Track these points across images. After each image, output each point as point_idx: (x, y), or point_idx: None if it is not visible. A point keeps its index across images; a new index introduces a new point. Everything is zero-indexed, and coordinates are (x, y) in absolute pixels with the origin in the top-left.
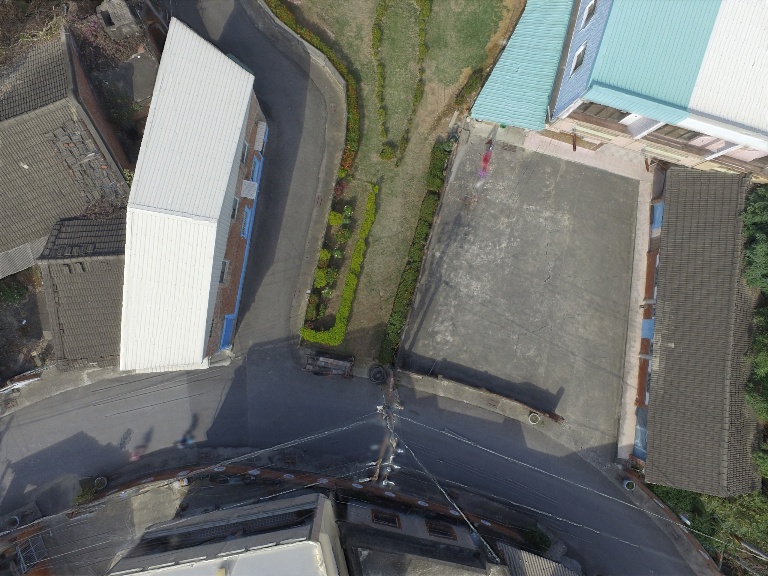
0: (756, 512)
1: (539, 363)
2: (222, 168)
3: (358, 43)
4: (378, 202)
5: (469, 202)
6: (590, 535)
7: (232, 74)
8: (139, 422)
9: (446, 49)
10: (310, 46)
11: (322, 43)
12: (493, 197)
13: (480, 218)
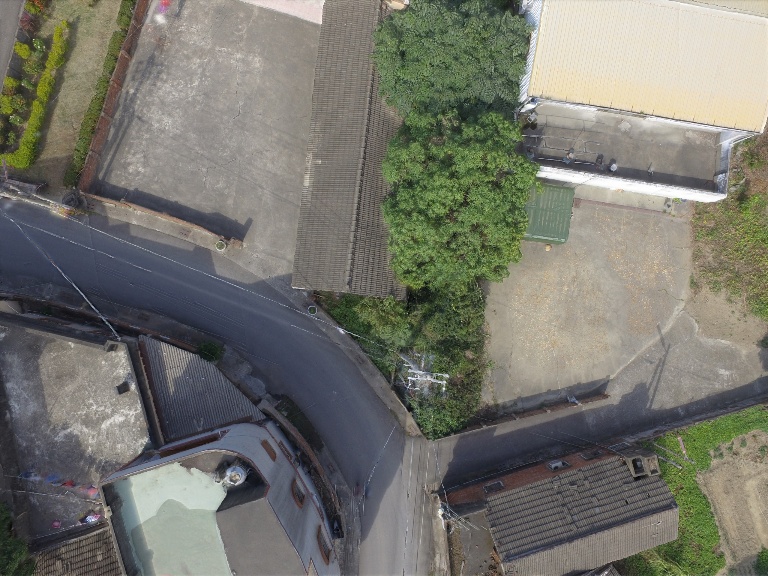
0: (393, 315)
1: (227, 195)
2: None
3: None
4: (74, 40)
5: (163, 43)
6: (275, 357)
7: None
8: None
9: None
10: None
11: None
12: (186, 39)
13: (173, 58)
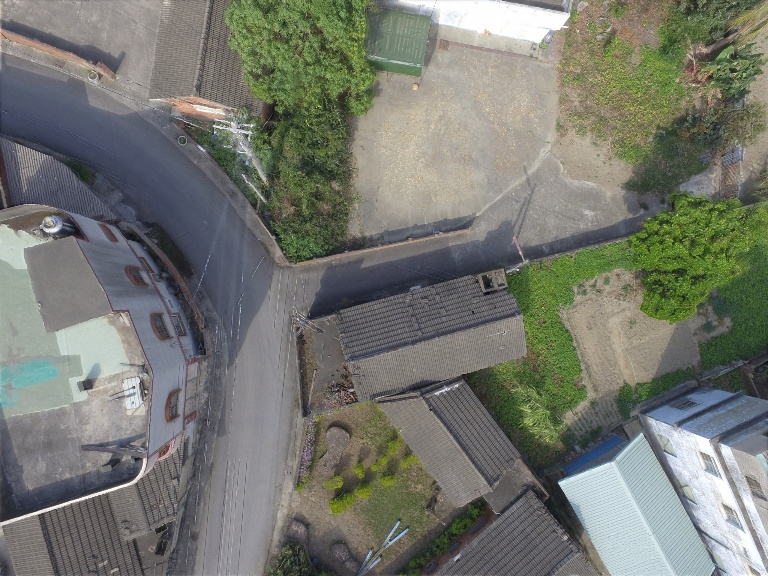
0: None
1: (101, 28)
2: None
3: None
4: None
5: None
6: (147, 186)
7: None
8: None
9: None
10: None
11: None
12: None
13: None
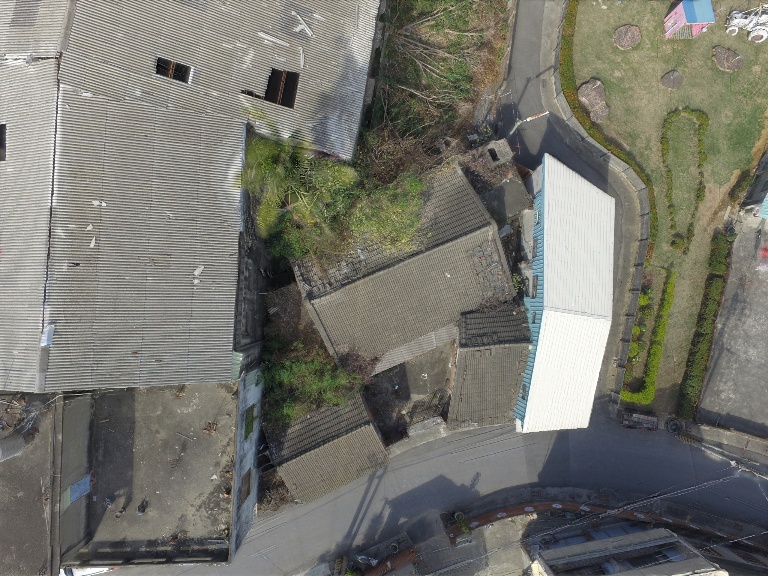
0: None
1: None
2: (606, 276)
3: (648, 153)
4: None
5: (744, 282)
6: None
7: (598, 198)
8: (485, 467)
9: (719, 155)
10: (617, 159)
11: (627, 156)
12: (764, 277)
13: (754, 295)
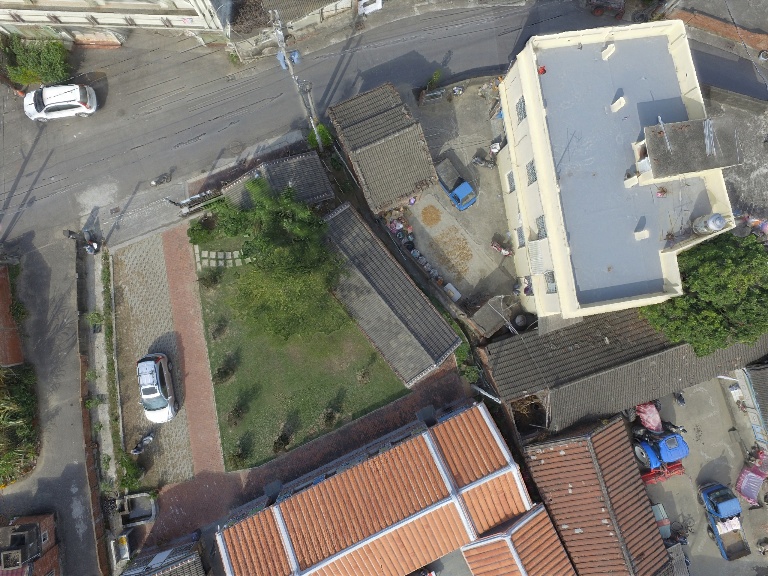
0: None
1: (767, 13)
2: None
3: None
4: None
5: None
6: None
7: None
8: (457, 46)
9: None
10: None
11: None
12: None
13: None
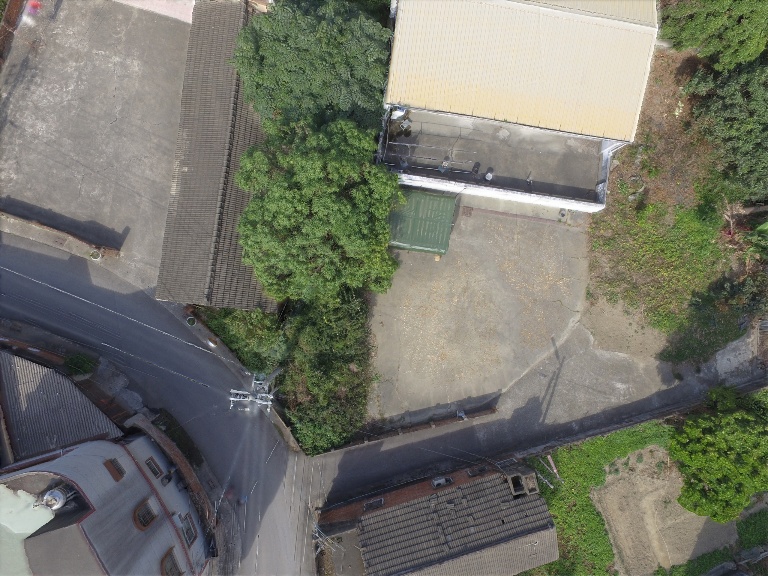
0: (260, 329)
1: (104, 202)
2: None
3: None
4: None
5: (37, 45)
6: (154, 370)
7: None
8: None
9: None
10: None
11: None
12: (62, 41)
13: (48, 61)
